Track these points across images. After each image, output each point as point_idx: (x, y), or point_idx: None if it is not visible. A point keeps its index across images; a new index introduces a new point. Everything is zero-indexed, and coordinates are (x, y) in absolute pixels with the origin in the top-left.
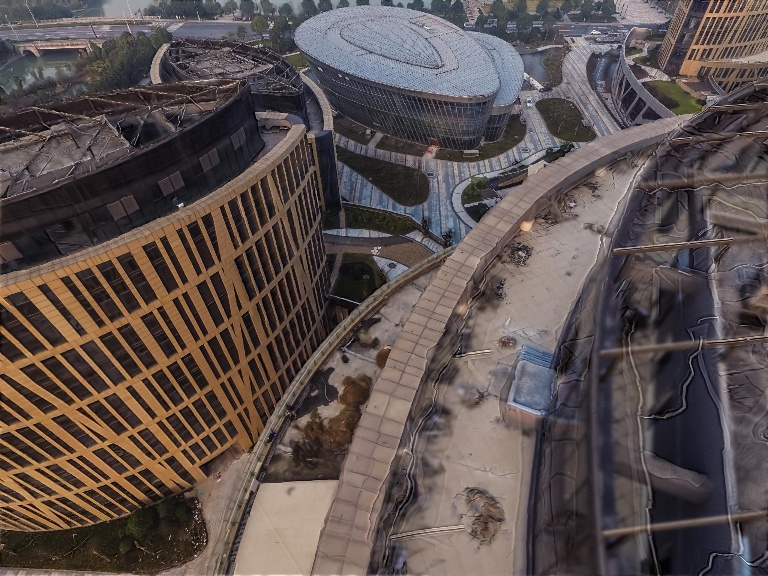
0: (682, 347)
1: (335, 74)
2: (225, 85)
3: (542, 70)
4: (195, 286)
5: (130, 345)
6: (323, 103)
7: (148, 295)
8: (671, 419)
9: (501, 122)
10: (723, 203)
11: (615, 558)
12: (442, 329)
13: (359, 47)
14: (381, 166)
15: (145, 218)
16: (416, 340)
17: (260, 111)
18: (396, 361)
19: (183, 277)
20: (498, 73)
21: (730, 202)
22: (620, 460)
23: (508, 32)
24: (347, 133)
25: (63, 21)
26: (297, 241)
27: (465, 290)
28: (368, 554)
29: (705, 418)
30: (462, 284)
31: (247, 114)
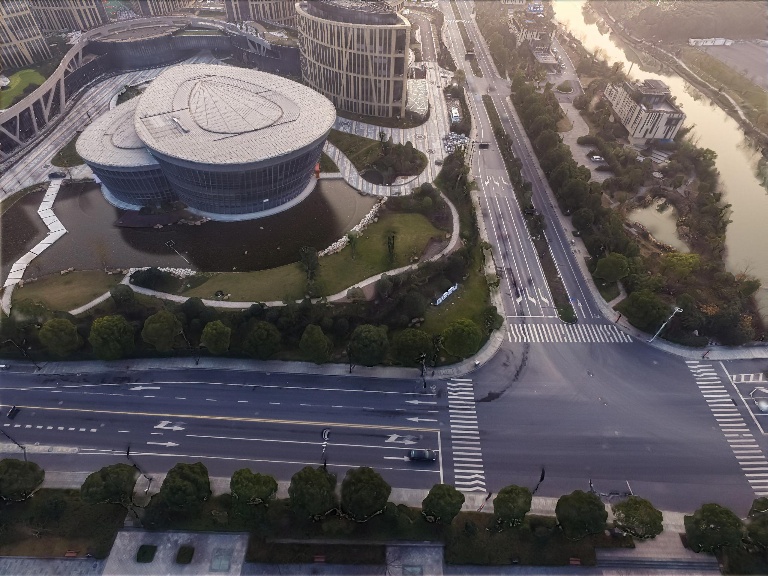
0: None
1: None
2: None
3: (5, 219)
4: None
5: None
6: (299, 8)
7: None
8: None
9: None
10: None
11: None
12: None
13: (266, 98)
14: None
15: None
16: None
17: None
18: None
19: None
20: None
21: None
22: None
23: None
24: None
25: None
26: None
27: None
28: None
29: None
30: None
31: None
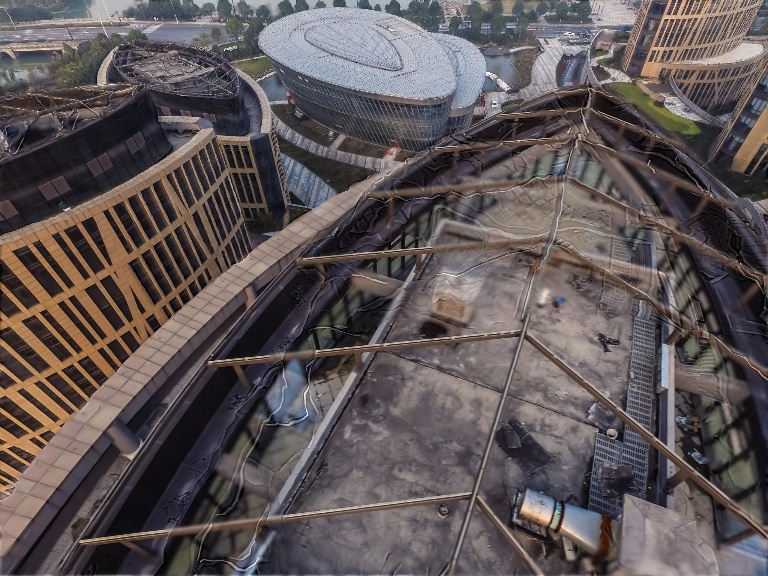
0: (304, 356)
1: (295, 76)
2: (121, 90)
3: (512, 72)
4: (83, 290)
5: (14, 349)
6: (264, 106)
7: (28, 299)
8: (293, 426)
9: (461, 124)
10: (450, 212)
11: (178, 563)
12: (189, 336)
13: (321, 49)
14: (340, 168)
15: (27, 223)
16: (159, 347)
17: (197, 114)
18: (127, 368)
19: (68, 281)
20: (456, 75)
21: (459, 211)
22: (232, 467)
23: (483, 33)
24: (310, 135)
25: (41, 23)
26: (210, 244)
27: (236, 297)
28: (5, 559)
29: (311, 426)
30: (235, 291)
31: (145, 119)
